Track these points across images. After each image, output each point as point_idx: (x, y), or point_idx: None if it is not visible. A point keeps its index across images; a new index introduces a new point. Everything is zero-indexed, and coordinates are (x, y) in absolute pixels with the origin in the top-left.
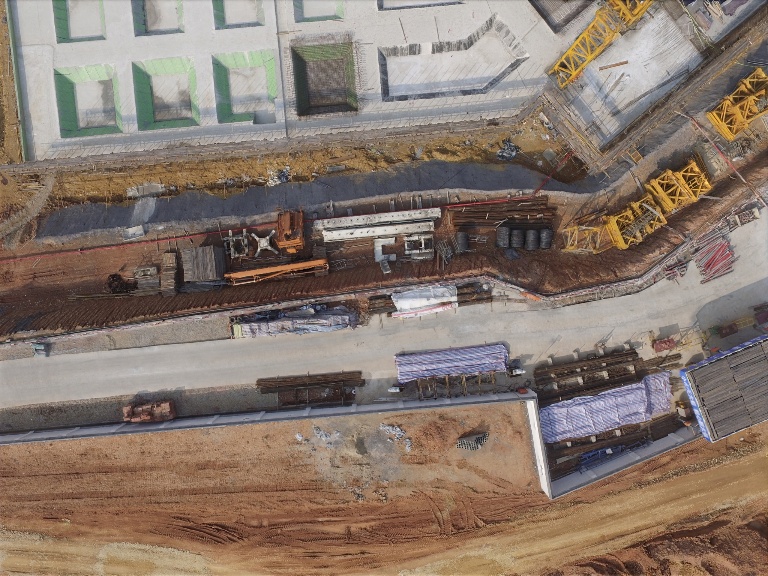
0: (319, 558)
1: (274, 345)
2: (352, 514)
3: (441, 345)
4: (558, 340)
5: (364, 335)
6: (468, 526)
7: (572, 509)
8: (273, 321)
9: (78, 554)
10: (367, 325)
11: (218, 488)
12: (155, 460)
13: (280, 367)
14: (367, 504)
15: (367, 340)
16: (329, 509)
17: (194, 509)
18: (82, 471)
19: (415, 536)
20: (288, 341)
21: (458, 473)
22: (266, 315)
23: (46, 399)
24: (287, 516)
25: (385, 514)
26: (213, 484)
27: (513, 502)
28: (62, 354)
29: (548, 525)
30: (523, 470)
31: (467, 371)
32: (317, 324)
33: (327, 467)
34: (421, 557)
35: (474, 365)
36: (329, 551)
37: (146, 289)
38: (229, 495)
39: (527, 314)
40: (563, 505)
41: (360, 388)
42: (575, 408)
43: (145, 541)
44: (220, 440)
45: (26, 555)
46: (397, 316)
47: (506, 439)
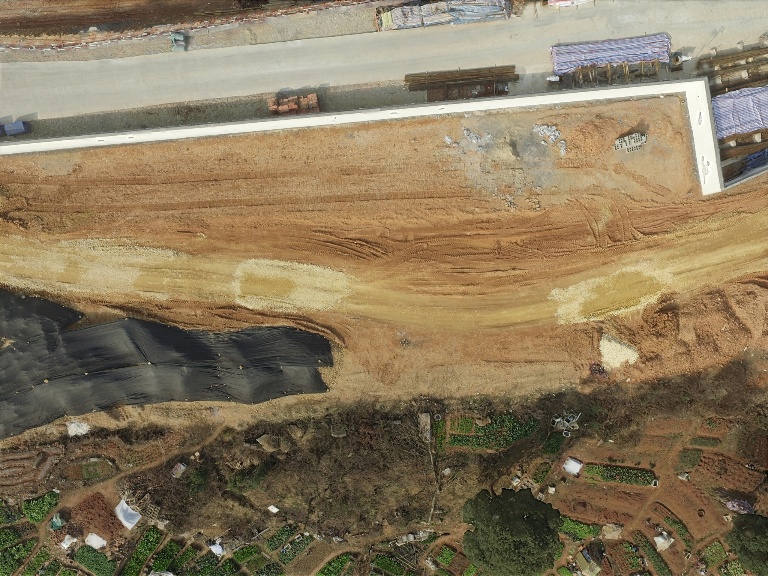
0: (467, 274)
1: (423, 38)
2: (502, 226)
3: (599, 36)
4: (721, 31)
5: (518, 26)
6: (625, 238)
7: (734, 220)
8: (426, 4)
9: (214, 272)
10: (521, 15)
11: (363, 195)
12: (297, 165)
13: (429, 62)
14: (518, 215)
15: (521, 32)
16: (478, 220)
17: (336, 221)
18: (220, 178)
19: (569, 249)
20: (438, 34)
21: (615, 179)
22: (415, 5)
23: (184, 98)
24: (434, 229)
25: (537, 226)
26: (358, 191)
27: (672, 212)
28: (201, 49)
29: (709, 237)
30: (683, 176)
31: (628, 60)
32: (473, 4)
33: (477, 173)
34: (575, 273)
35: (635, 54)
36: (478, 267)
37: (278, 3)
38: (375, 202)
39: (689, 2)
40: (725, 215)
41: (513, 84)
42: (742, 100)
43: (284, 257)
44: (365, 144)
45: (159, 273)
46: (553, 4)
47: (666, 141)
